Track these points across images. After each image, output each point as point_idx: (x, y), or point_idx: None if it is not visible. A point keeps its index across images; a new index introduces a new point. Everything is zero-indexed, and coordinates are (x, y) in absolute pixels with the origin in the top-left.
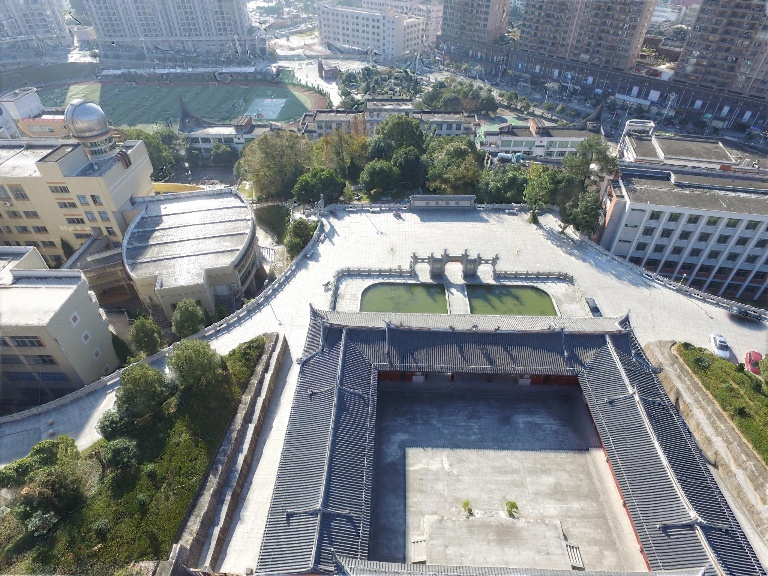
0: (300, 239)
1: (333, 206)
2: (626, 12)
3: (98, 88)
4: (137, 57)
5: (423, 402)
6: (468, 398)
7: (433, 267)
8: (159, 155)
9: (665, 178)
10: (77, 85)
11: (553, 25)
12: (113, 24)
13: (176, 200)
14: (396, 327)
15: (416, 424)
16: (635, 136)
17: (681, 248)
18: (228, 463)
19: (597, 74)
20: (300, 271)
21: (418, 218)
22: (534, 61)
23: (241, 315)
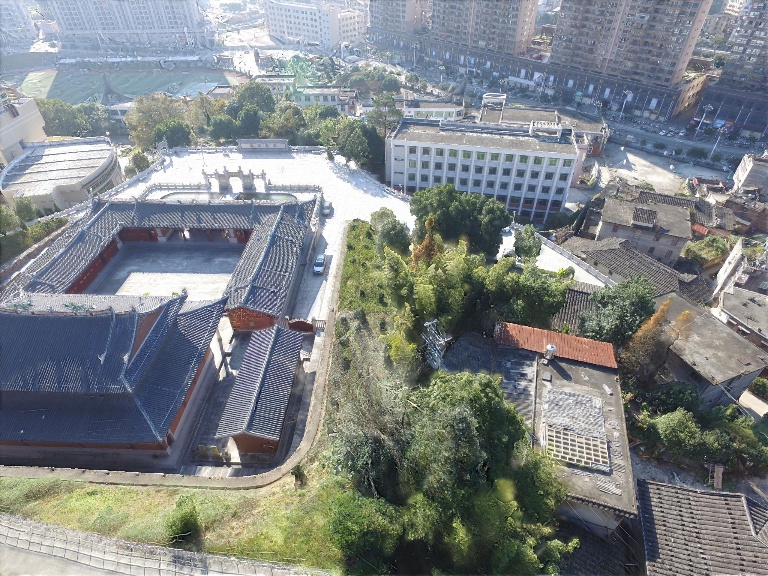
0: (142, 170)
1: (179, 148)
2: (509, 2)
3: (54, 74)
4: (92, 47)
5: (159, 252)
6: (191, 250)
7: (221, 182)
8: (73, 121)
9: (437, 125)
10: (36, 72)
11: (456, 15)
12: (74, 18)
13: (59, 146)
14: (142, 201)
15: (147, 262)
16: (490, 107)
17: (439, 177)
18: (4, 273)
19: (493, 59)
20: (129, 188)
21: (241, 156)
22: (444, 48)
23: (71, 213)
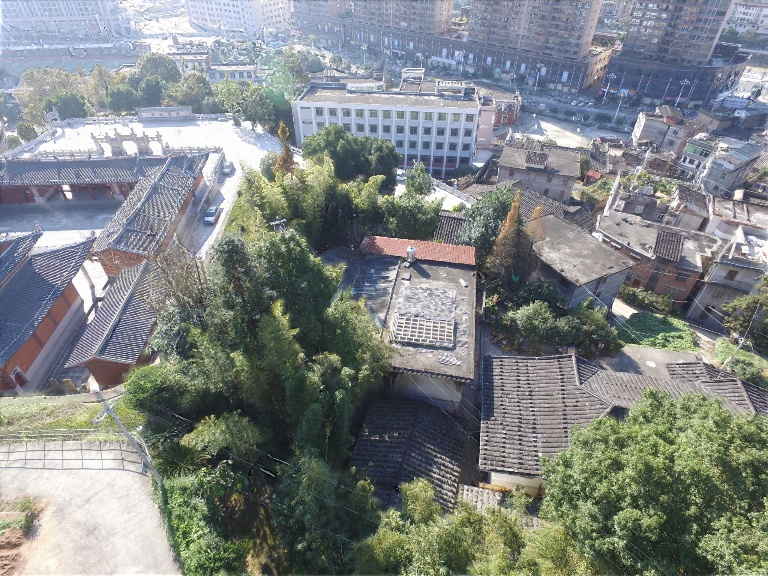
0: (29, 141)
1: (73, 120)
2: None
3: None
4: None
5: (36, 212)
6: (73, 209)
7: (113, 146)
8: None
9: (345, 88)
10: None
11: None
12: None
13: None
14: (13, 159)
15: (20, 222)
16: (410, 81)
17: None
18: None
19: (415, 39)
20: None
21: (142, 125)
22: (368, 31)
23: None
